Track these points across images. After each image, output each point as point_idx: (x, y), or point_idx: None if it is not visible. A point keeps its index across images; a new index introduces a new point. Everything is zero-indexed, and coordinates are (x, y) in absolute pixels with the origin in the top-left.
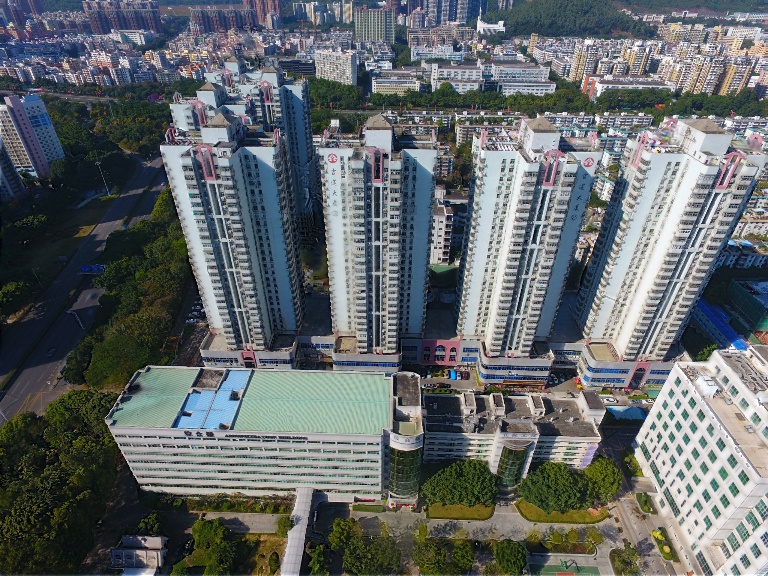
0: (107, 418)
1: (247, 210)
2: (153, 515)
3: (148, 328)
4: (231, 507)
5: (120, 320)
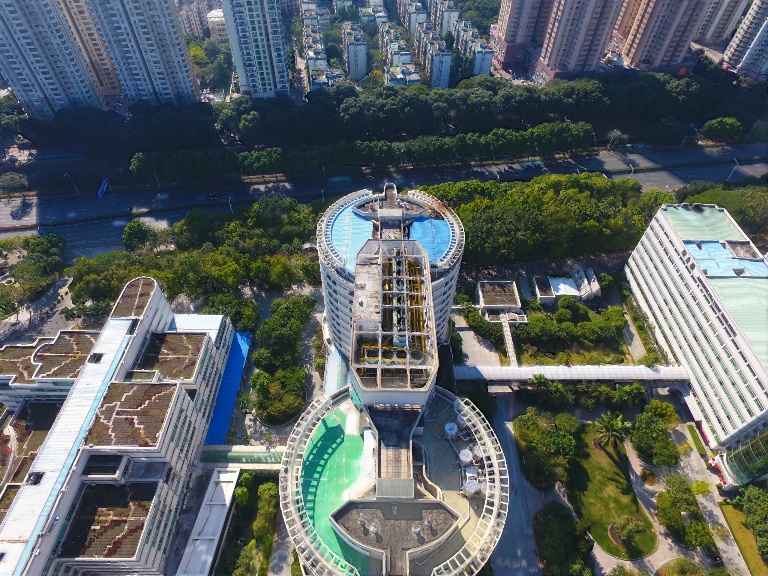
0: (666, 204)
1: None
2: (611, 278)
3: (762, 209)
4: (640, 328)
5: (755, 191)
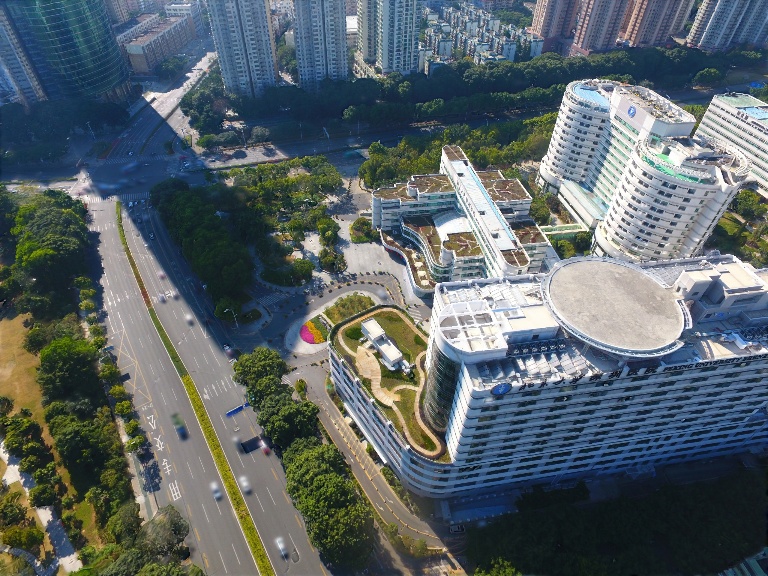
0: (716, 95)
1: None
2: None
3: None
4: None
5: None
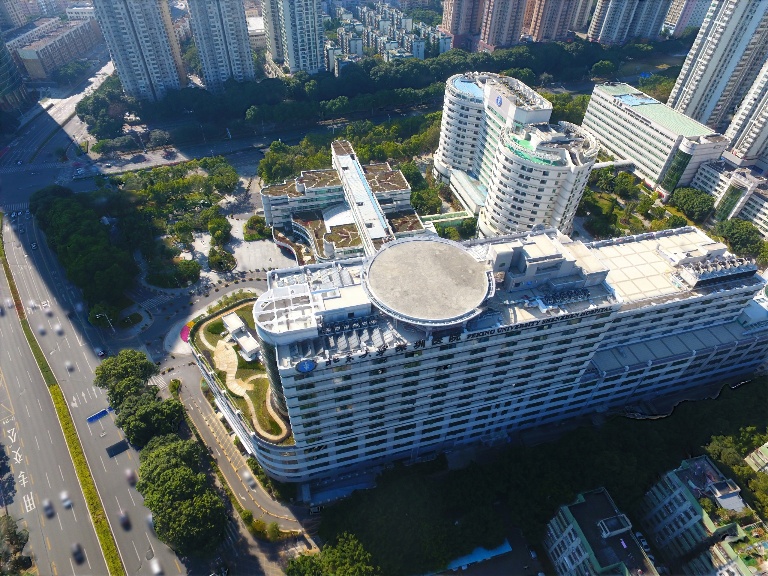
0: None
1: (735, 25)
2: None
3: None
4: (599, 156)
5: None
